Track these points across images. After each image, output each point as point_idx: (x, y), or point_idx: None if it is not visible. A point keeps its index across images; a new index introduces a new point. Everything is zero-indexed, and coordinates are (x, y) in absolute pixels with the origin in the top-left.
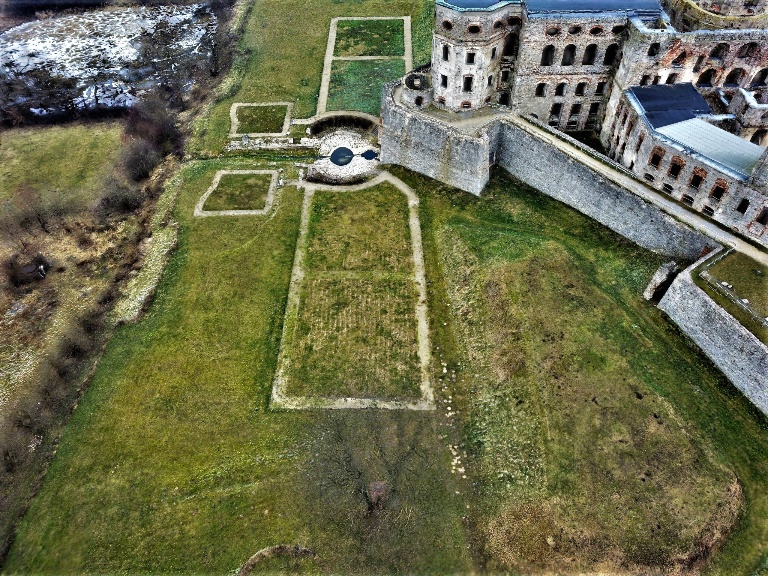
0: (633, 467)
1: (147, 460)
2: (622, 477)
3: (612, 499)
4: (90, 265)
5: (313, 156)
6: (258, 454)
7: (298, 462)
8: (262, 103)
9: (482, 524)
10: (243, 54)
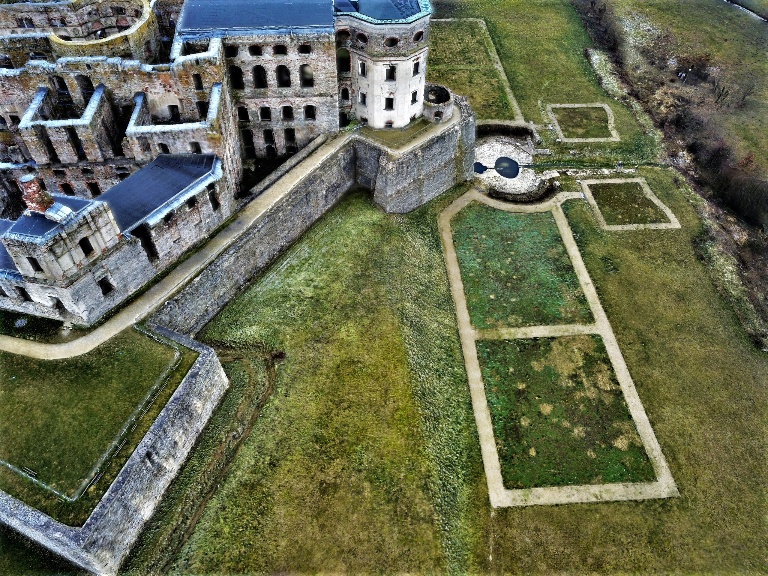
0: None
1: (530, 5)
2: None
3: None
4: (655, 84)
5: (538, 167)
6: (481, 7)
7: (461, 4)
8: (643, 228)
9: None
10: (762, 338)
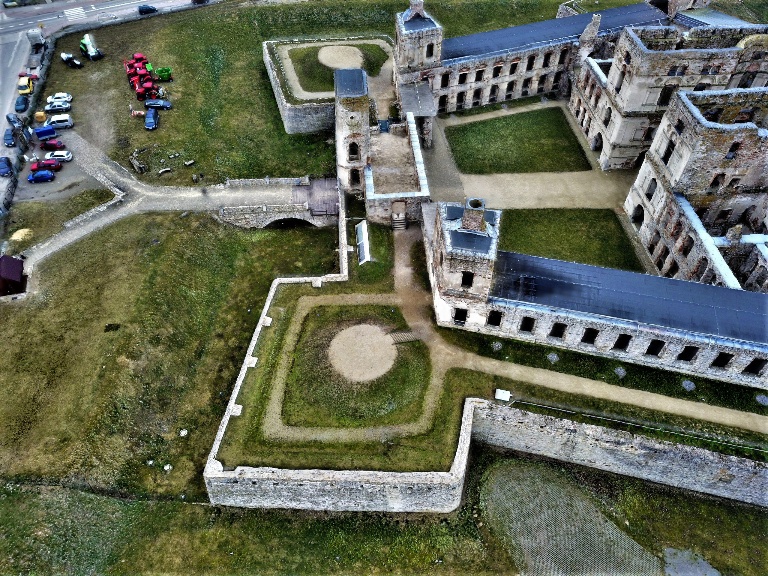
0: (709, 7)
1: None
2: (714, 5)
3: (716, 1)
4: None
5: None
6: None
7: None
8: None
9: (759, 16)
10: None
